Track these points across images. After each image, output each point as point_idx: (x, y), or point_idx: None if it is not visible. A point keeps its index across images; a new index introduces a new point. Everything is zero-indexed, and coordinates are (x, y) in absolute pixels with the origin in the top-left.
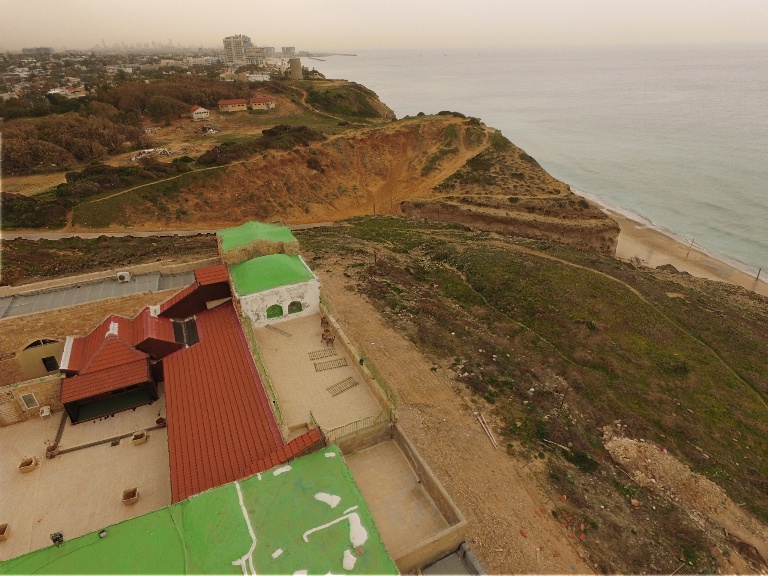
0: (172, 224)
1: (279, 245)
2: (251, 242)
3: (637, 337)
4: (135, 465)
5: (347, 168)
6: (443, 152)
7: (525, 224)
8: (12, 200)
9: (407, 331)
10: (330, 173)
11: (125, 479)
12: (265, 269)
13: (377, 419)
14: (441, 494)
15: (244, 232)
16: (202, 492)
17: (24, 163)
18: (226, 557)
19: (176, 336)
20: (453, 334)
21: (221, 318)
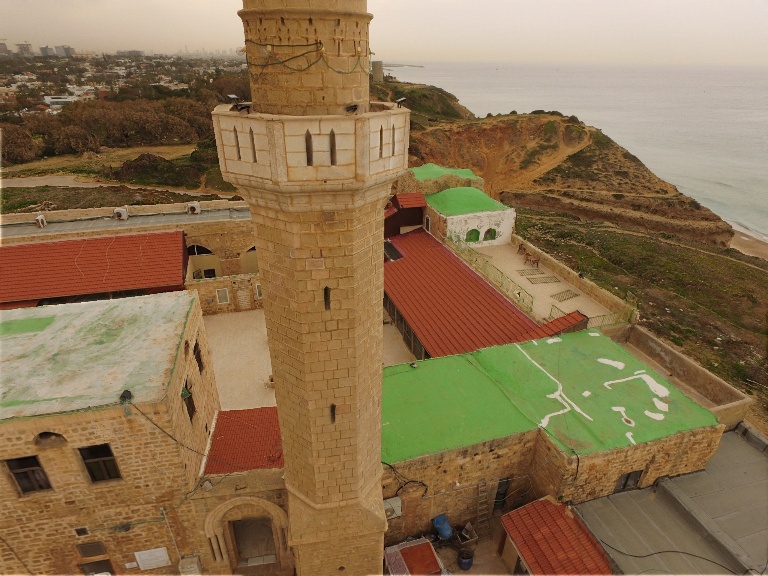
0: None
1: (466, 182)
2: (442, 176)
3: None
4: None
5: (445, 157)
6: (543, 147)
7: (630, 221)
8: (156, 161)
9: None
10: (429, 161)
11: None
12: (465, 196)
13: (619, 318)
14: (711, 379)
15: (428, 170)
16: (488, 347)
17: (155, 134)
18: (540, 391)
19: None
20: (617, 288)
21: (418, 240)
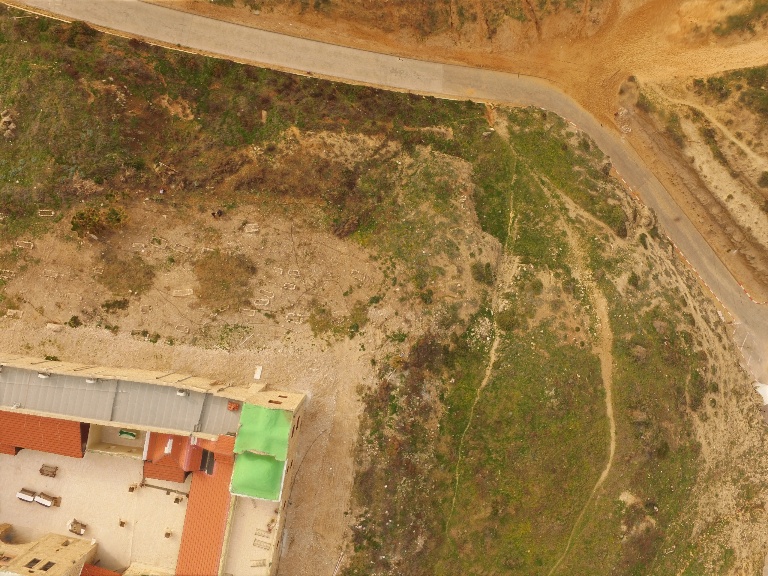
0: (307, 15)
1: None
2: (254, 451)
3: (525, 526)
4: (173, 514)
5: None
6: None
7: None
8: None
9: (360, 467)
10: None
11: (168, 520)
12: (251, 484)
13: None
14: None
15: (258, 425)
16: None
17: None
18: None
19: (202, 463)
20: (385, 487)
21: (228, 466)
